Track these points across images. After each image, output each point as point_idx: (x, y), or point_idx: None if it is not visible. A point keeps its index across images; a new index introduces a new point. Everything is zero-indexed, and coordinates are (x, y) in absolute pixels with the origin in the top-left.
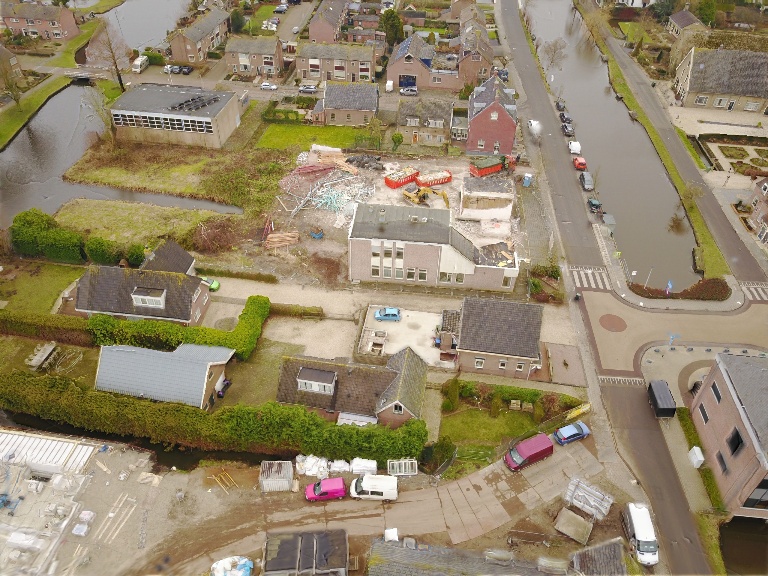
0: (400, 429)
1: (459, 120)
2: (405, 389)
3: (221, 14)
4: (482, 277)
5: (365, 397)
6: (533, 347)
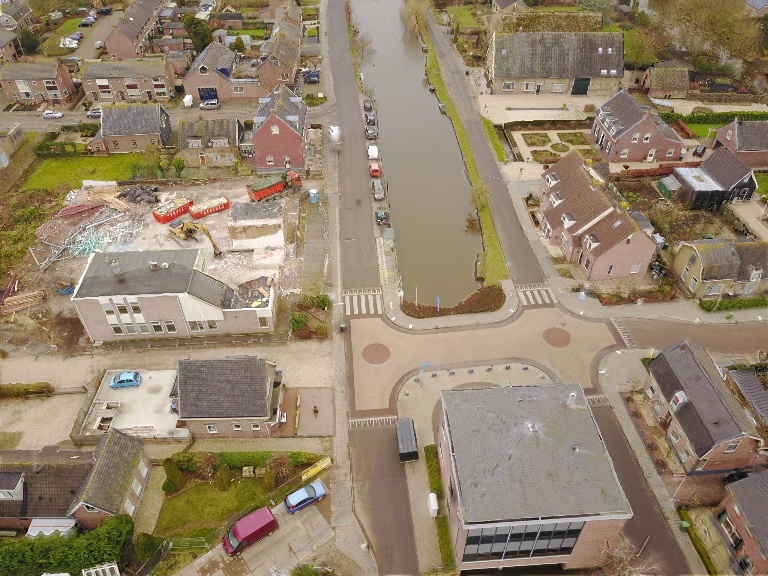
0: (89, 533)
1: (249, 135)
2: (98, 483)
3: (4, 35)
4: (235, 321)
5: (60, 497)
6: (261, 405)
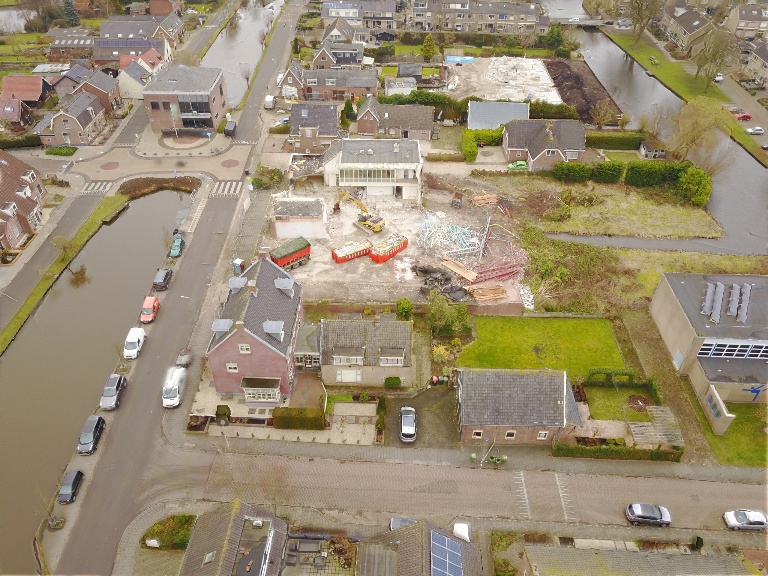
0: None
1: (311, 343)
2: None
3: None
4: None
5: None
6: None
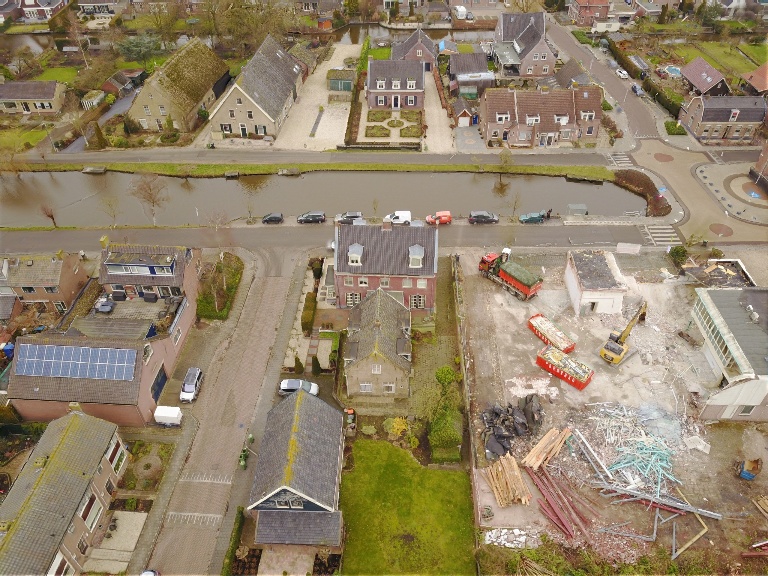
0: None
1: None
2: None
3: None
4: None
5: None
6: None
